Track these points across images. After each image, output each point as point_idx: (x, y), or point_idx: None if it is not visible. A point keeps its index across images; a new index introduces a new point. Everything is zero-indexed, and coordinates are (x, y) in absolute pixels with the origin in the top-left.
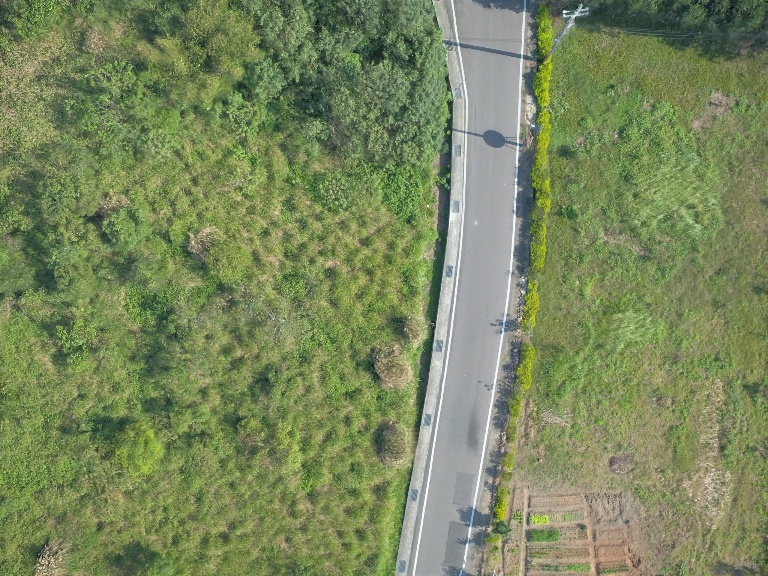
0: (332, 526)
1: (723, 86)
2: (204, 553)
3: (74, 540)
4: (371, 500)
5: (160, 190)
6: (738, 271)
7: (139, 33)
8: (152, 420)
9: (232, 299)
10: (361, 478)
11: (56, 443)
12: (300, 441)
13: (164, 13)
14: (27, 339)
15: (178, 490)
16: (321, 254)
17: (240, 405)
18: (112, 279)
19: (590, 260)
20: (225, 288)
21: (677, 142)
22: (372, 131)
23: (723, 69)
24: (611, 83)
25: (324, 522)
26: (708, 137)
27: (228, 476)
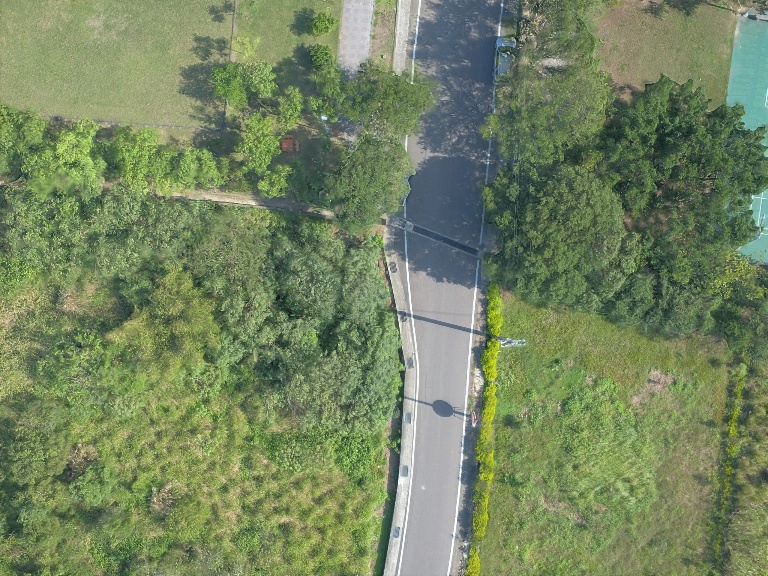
0: None
1: (662, 365)
2: None
3: None
4: None
5: (126, 443)
6: (669, 543)
7: (110, 291)
8: None
9: (191, 548)
10: None
11: None
12: None
13: (132, 286)
14: None
15: None
16: (276, 511)
17: None
18: (78, 529)
19: (530, 527)
20: None
21: (616, 417)
22: (325, 409)
23: (663, 348)
24: (556, 357)
25: None
26: (646, 413)
27: None
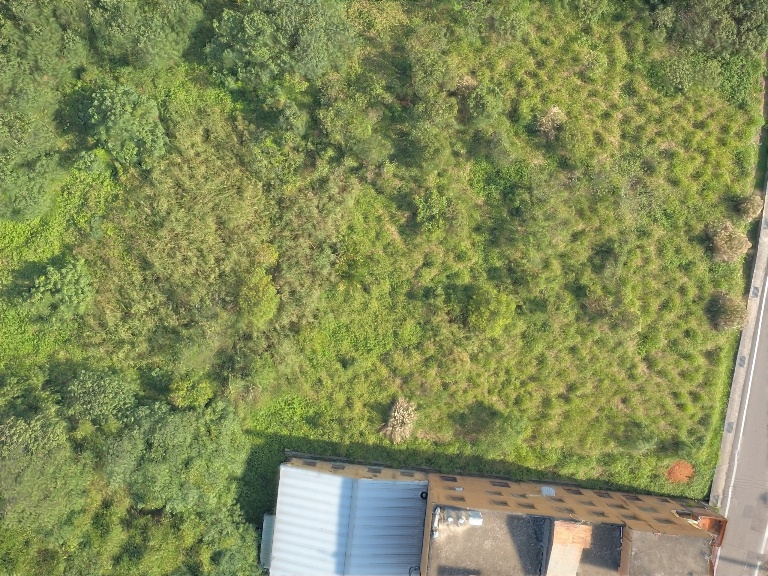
0: (669, 388)
1: None
2: (547, 412)
3: (419, 400)
4: (703, 365)
5: (505, 72)
6: None
7: None
8: (496, 288)
9: None
10: (697, 344)
11: (404, 308)
12: (638, 309)
13: None
14: (376, 210)
15: (520, 354)
16: (659, 136)
17: (583, 274)
18: (463, 153)
19: None
20: (568, 165)
21: None
22: (723, 17)
23: None
24: None
25: (661, 384)
26: None
27: (571, 340)
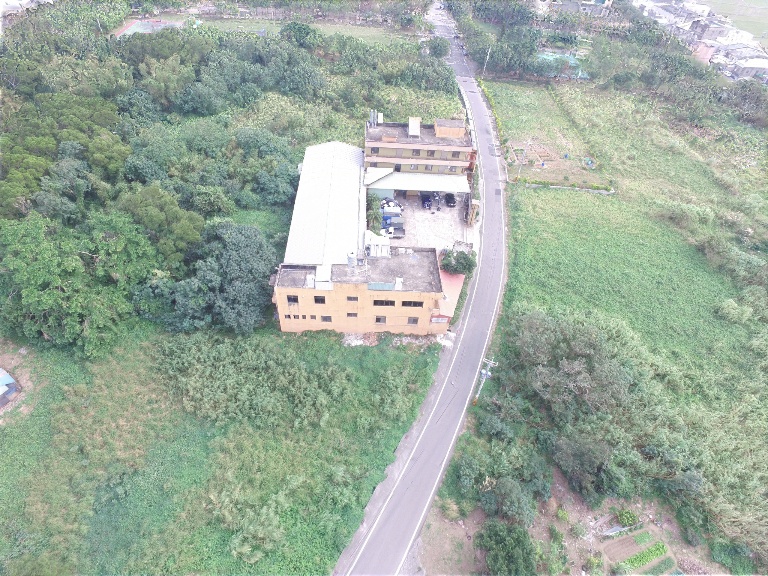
0: None
1: (529, 90)
2: None
3: None
4: None
5: None
6: None
7: None
8: None
9: None
10: None
11: None
12: None
13: None
14: None
15: None
16: None
17: None
18: None
19: None
20: None
21: None
22: None
23: None
24: None
25: None
26: None
27: None
